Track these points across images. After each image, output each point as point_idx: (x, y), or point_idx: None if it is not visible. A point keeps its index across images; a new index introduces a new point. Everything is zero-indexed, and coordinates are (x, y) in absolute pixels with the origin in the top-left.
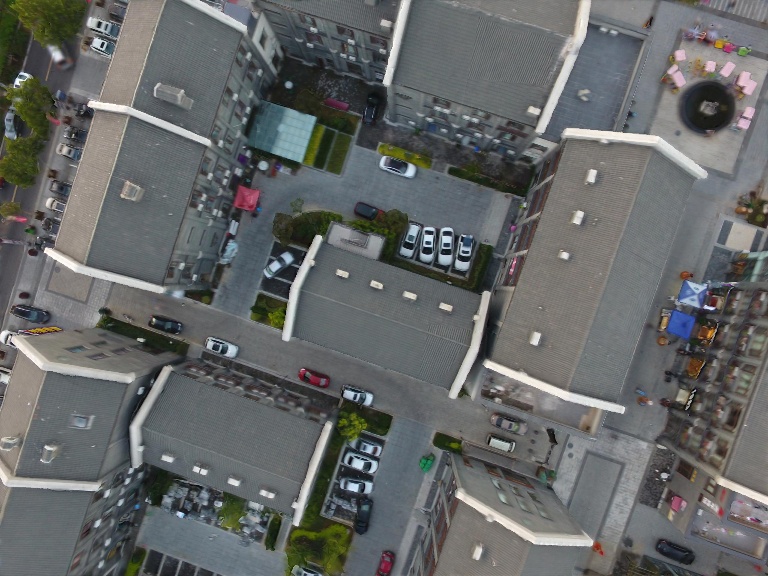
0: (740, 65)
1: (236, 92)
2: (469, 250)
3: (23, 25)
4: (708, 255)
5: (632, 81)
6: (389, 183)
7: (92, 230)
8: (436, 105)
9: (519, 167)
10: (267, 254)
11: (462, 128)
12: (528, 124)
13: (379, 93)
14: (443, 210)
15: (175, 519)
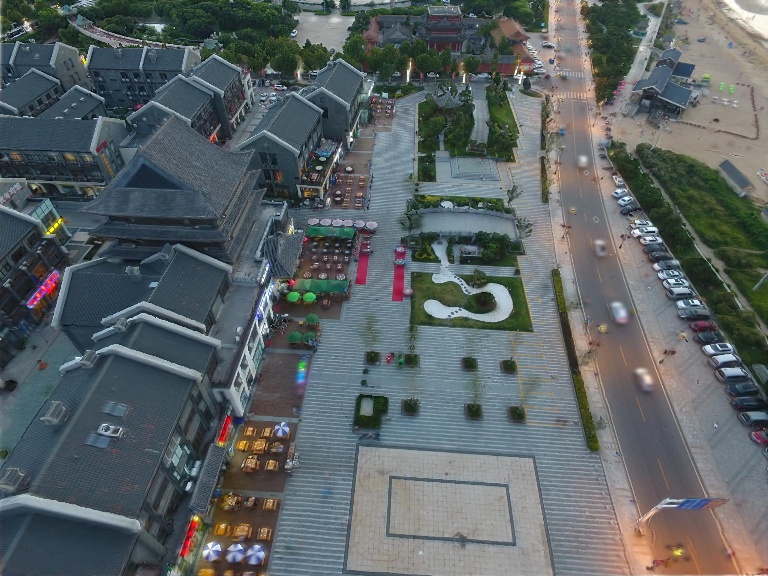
0: None
1: (168, 81)
2: None
3: None
4: None
5: None
6: None
7: None
8: None
9: None
10: None
11: None
12: None
13: None
14: None
15: None
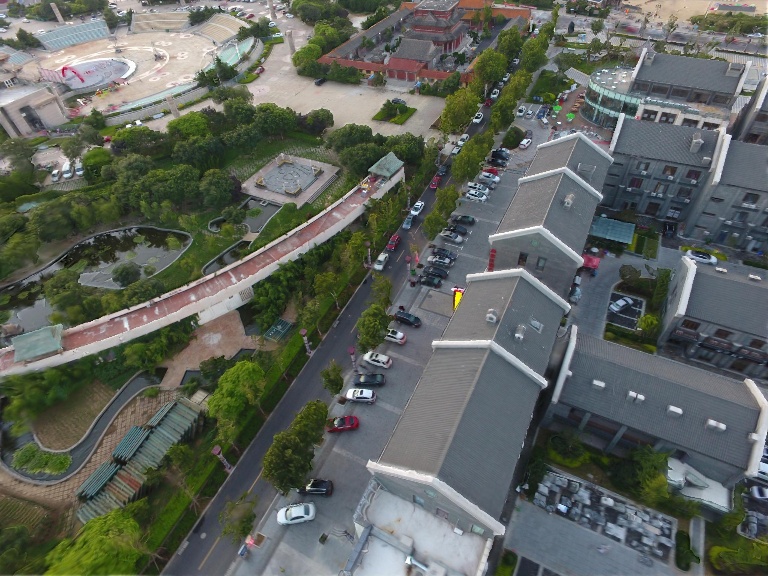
0: None
1: None
2: None
3: (456, 165)
4: None
5: None
6: None
7: (545, 214)
8: (744, 203)
9: None
10: (607, 299)
11: (756, 227)
12: None
13: None
14: None
15: (550, 520)
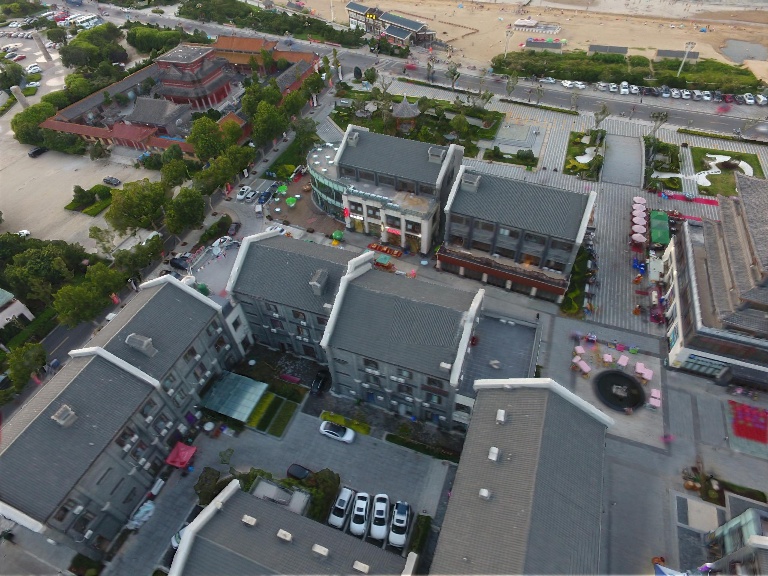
0: (635, 360)
1: (200, 354)
2: (404, 519)
3: None
4: (674, 537)
5: (532, 354)
6: (327, 447)
7: (4, 449)
8: (367, 367)
9: (455, 436)
10: (183, 519)
11: (394, 393)
12: (443, 378)
13: (328, 371)
14: (379, 476)
15: None
